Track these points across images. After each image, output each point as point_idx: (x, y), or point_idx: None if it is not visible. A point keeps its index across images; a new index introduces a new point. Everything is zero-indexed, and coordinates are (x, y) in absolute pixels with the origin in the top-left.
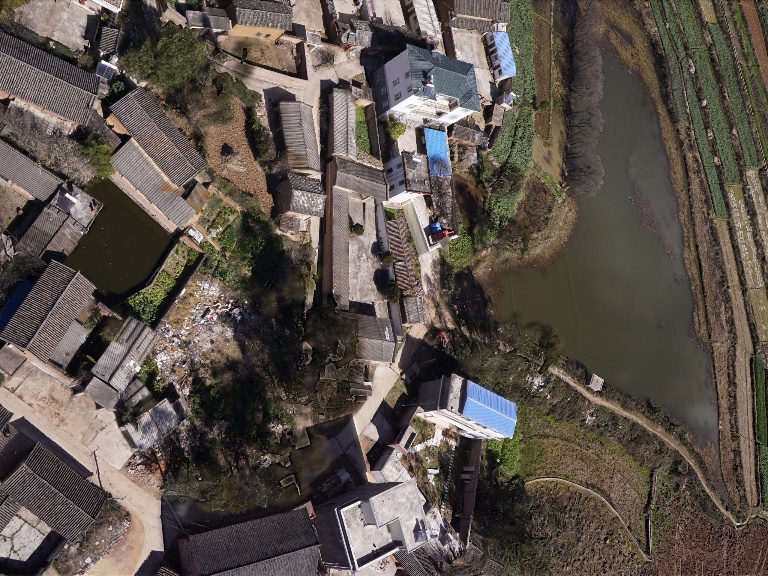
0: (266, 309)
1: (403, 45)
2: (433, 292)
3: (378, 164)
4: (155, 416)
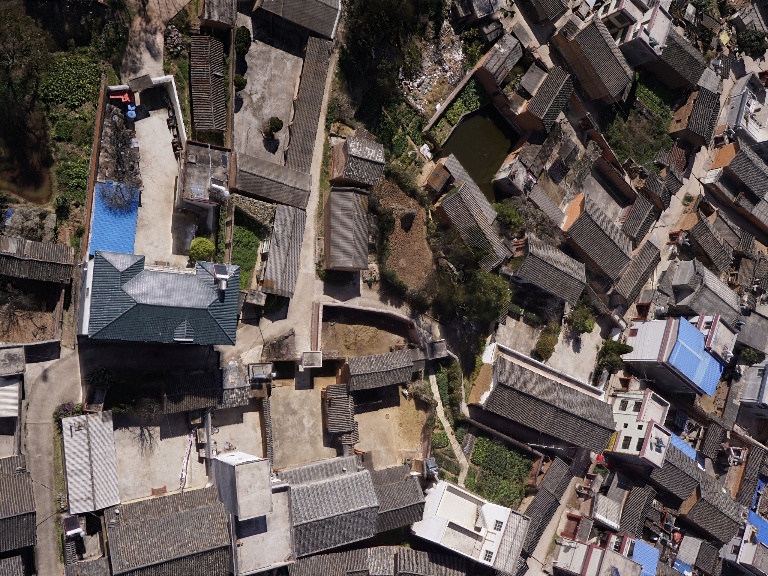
0: (381, 68)
1: (166, 382)
2: (144, 31)
3: (240, 201)
4: (489, 7)
